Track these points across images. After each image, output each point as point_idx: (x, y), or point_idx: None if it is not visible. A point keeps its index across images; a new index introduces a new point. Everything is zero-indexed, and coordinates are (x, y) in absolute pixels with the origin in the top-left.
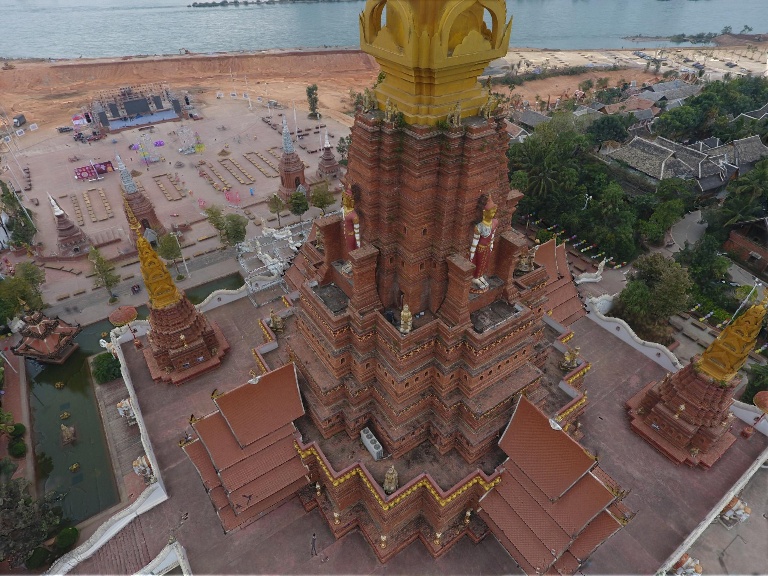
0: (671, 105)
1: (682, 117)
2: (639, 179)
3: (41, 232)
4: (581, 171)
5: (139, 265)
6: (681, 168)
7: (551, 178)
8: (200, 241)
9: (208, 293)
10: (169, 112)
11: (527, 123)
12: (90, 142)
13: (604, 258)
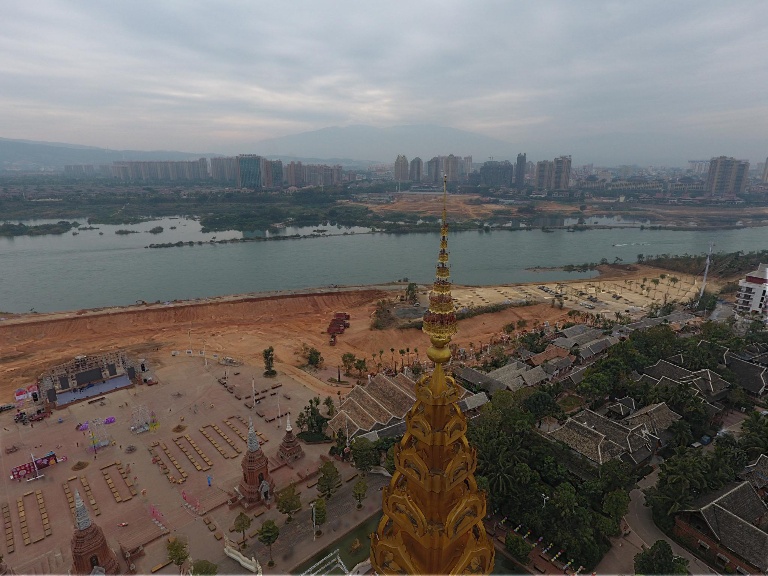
0: (583, 351)
1: (599, 385)
2: (582, 463)
3: None
4: (530, 454)
5: None
6: (614, 449)
7: (507, 474)
8: (154, 572)
9: None
10: (122, 378)
11: (468, 380)
12: (32, 423)
13: (575, 573)
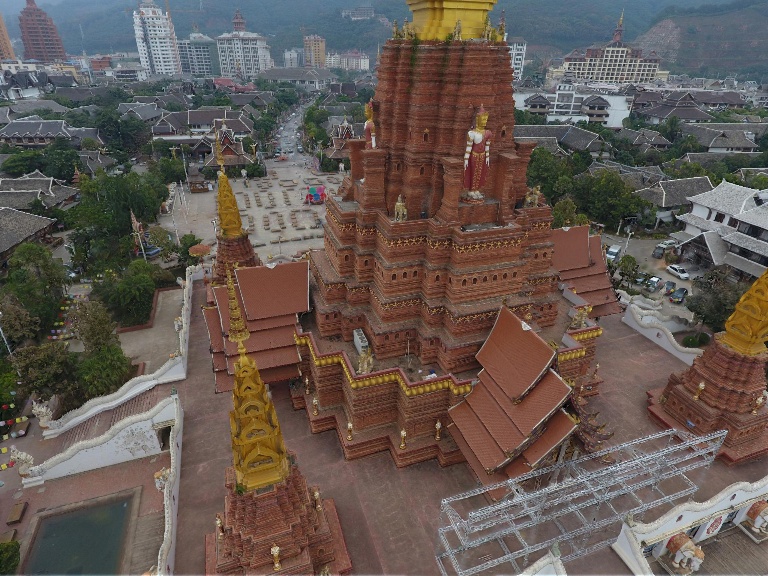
0: None
1: None
2: None
3: None
4: None
5: None
6: None
7: None
8: None
9: None
10: None
11: None
12: None
13: (14, 449)
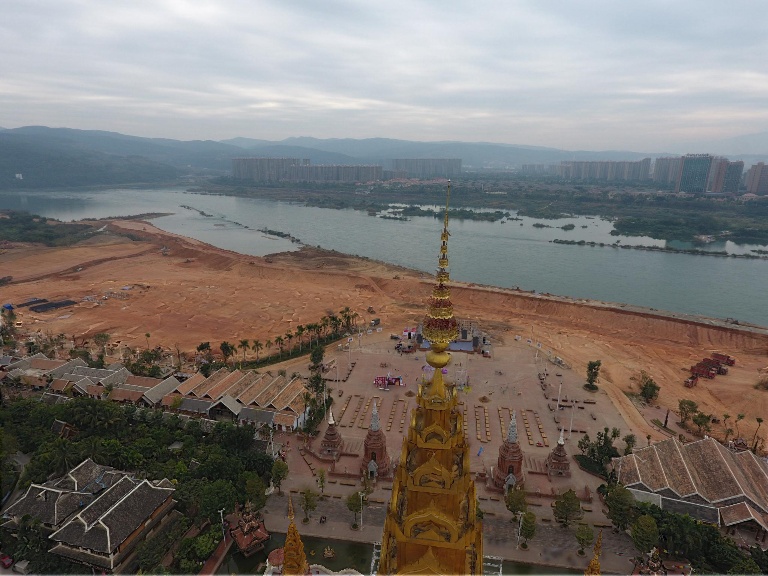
0: None
1: None
2: None
3: (327, 421)
4: None
5: (351, 488)
6: None
7: None
8: None
9: (363, 554)
10: (469, 344)
11: None
12: (402, 353)
13: None
